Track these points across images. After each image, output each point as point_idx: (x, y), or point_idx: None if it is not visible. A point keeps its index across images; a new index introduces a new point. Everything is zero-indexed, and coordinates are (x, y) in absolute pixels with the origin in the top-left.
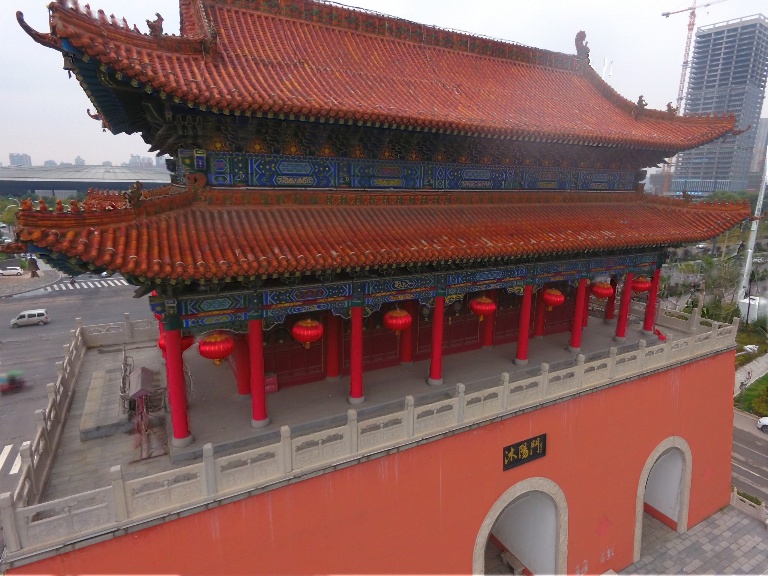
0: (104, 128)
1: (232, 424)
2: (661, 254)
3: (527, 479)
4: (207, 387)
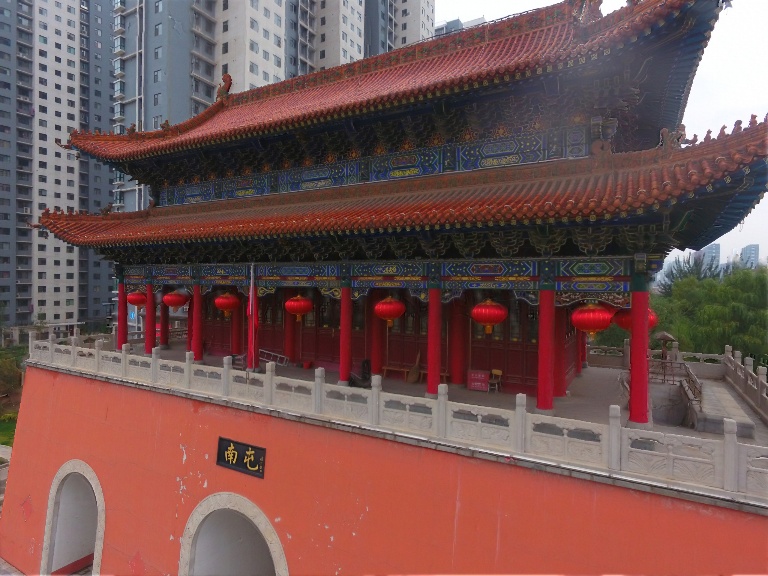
0: (727, 2)
1: (599, 370)
2: None
3: None
4: (604, 385)
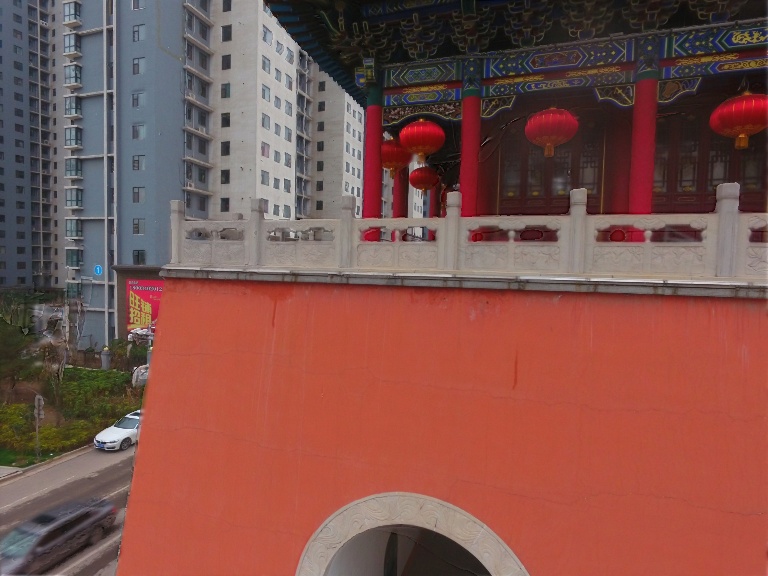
0: None
1: None
2: (454, 164)
3: None
4: None
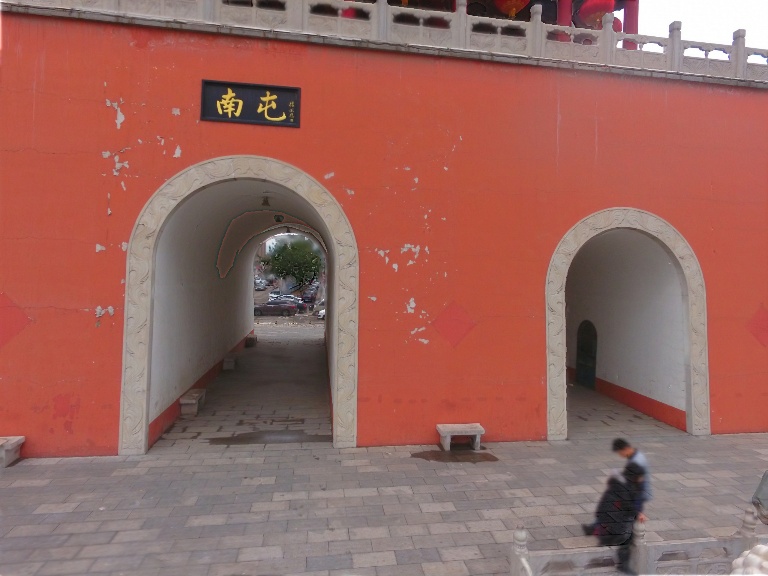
0: None
1: None
2: None
3: (288, 223)
4: None
